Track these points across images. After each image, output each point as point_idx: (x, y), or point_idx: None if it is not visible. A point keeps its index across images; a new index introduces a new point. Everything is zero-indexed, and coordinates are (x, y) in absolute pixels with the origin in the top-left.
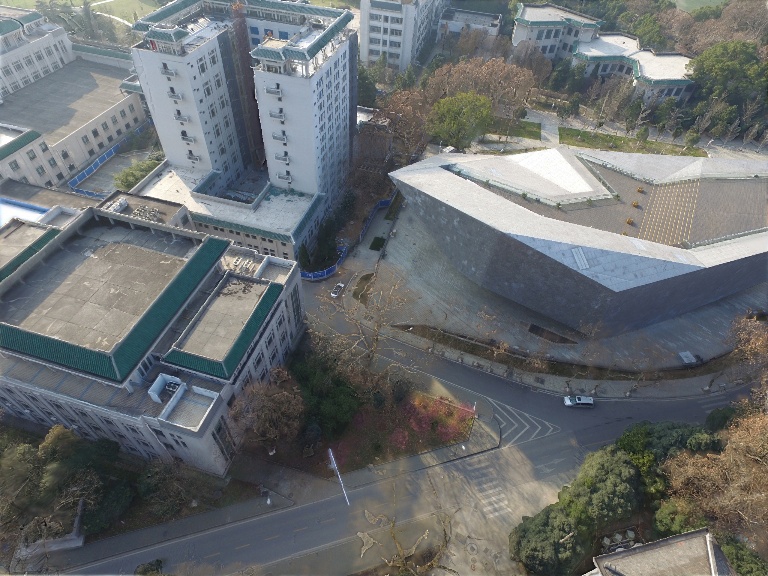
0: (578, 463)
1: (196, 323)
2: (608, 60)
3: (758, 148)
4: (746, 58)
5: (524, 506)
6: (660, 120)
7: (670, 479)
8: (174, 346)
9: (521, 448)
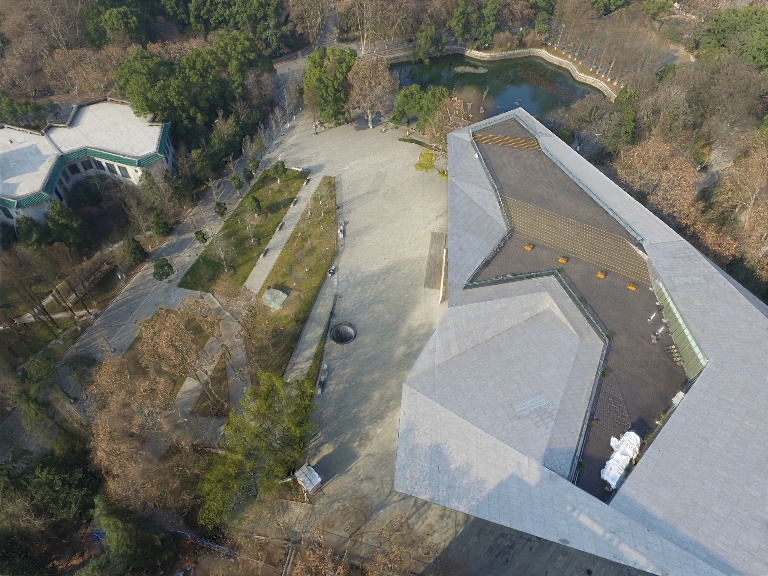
0: None
1: None
2: (57, 175)
3: (281, 132)
4: (168, 68)
5: None
6: None
7: None
8: None
9: None
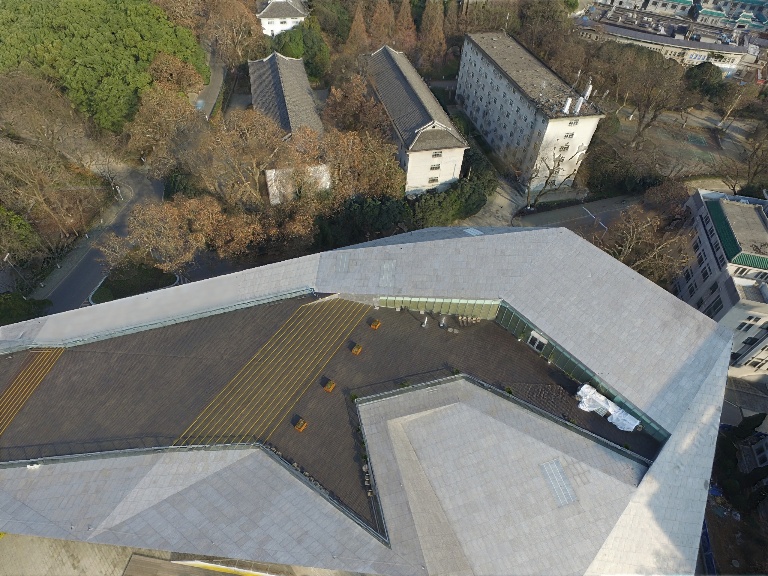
0: None
1: (765, 223)
2: None
3: None
4: None
5: None
6: None
7: None
8: (761, 206)
9: None
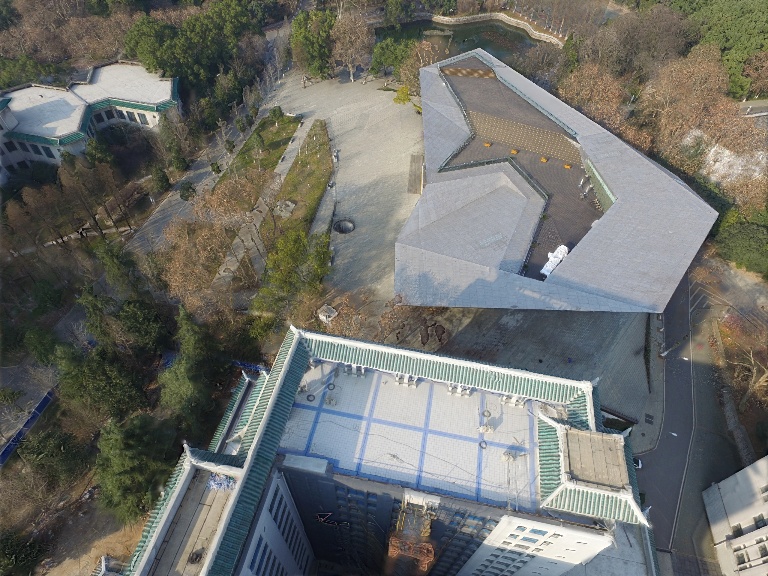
0: (711, 264)
1: None
2: (87, 120)
3: (274, 87)
4: (171, 31)
5: (766, 297)
6: (217, 125)
7: (743, 208)
8: None
9: (723, 294)
